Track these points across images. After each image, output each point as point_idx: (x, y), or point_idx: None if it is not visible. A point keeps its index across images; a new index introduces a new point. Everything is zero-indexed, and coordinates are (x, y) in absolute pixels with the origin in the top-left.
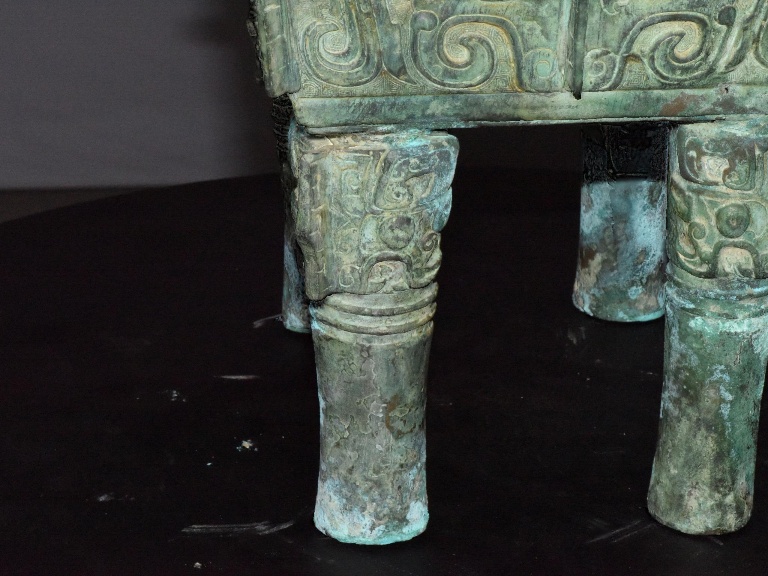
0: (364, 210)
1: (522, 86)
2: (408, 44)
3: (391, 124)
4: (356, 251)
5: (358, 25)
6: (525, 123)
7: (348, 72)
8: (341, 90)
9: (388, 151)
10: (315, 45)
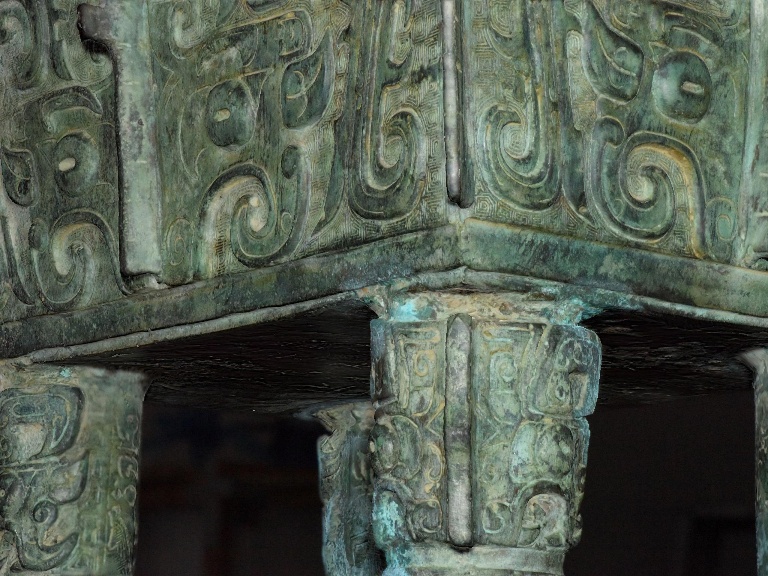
0: (519, 413)
1: (703, 247)
2: (589, 163)
3: (556, 286)
4: (505, 478)
5: (544, 119)
6: (690, 314)
7: (529, 186)
8: (517, 213)
9: (551, 326)
10: (497, 137)
